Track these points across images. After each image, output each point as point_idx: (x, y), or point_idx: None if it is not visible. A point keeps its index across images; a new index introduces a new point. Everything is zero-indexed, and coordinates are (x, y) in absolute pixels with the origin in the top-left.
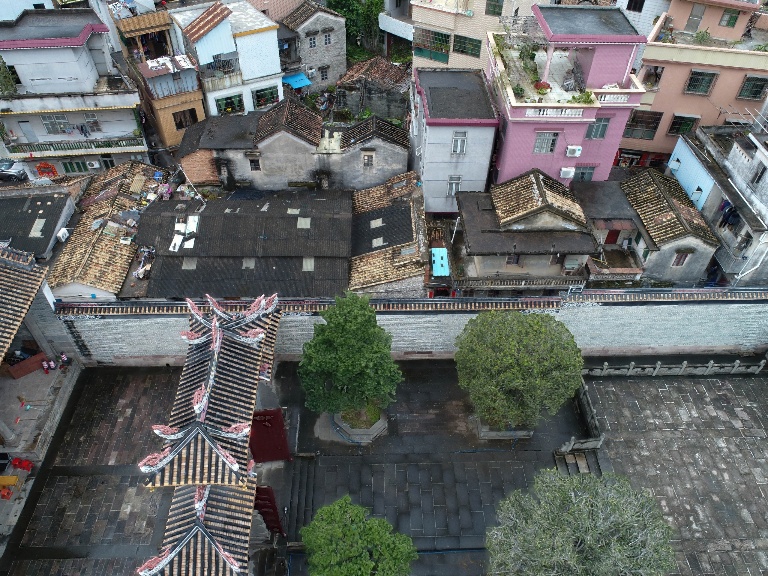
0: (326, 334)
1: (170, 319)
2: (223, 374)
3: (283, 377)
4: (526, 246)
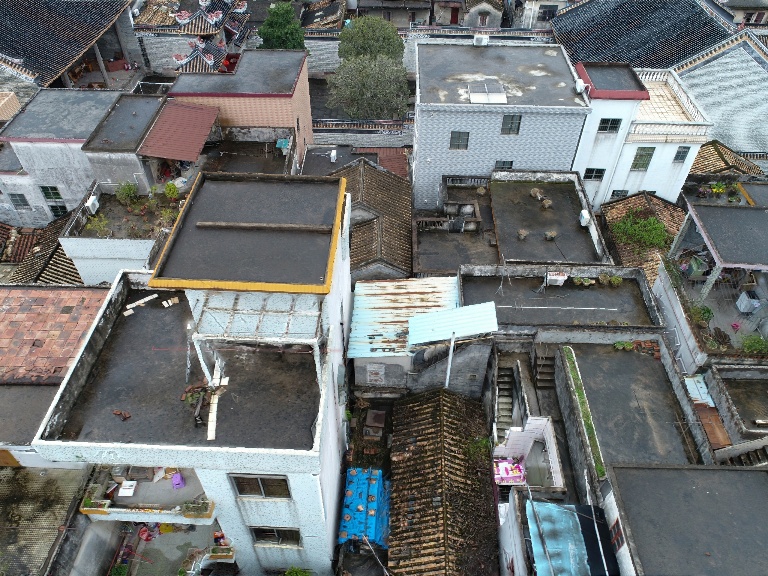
0: (269, 18)
1: (194, 39)
2: (214, 5)
3: None
4: (391, 5)
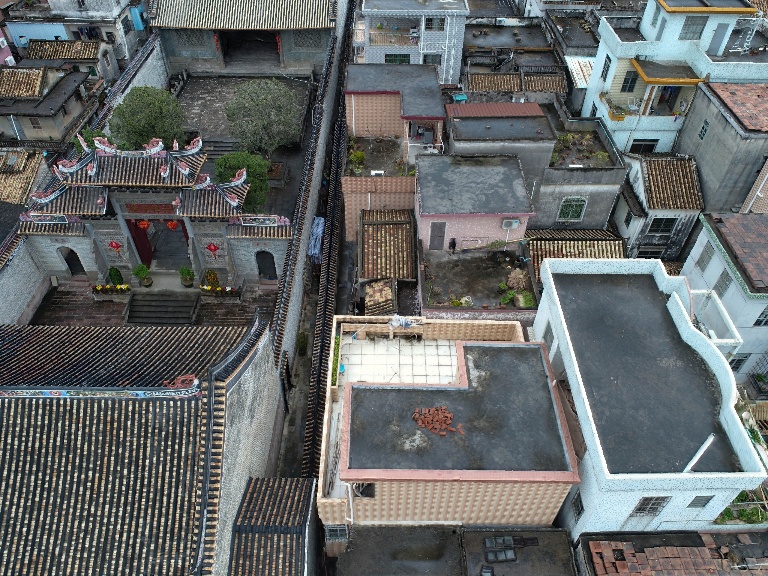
0: None
1: None
2: None
3: (73, 271)
4: None
